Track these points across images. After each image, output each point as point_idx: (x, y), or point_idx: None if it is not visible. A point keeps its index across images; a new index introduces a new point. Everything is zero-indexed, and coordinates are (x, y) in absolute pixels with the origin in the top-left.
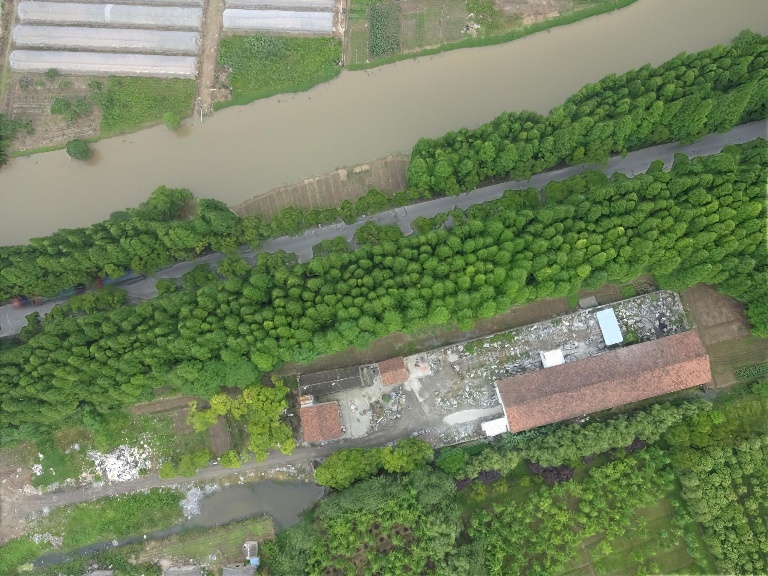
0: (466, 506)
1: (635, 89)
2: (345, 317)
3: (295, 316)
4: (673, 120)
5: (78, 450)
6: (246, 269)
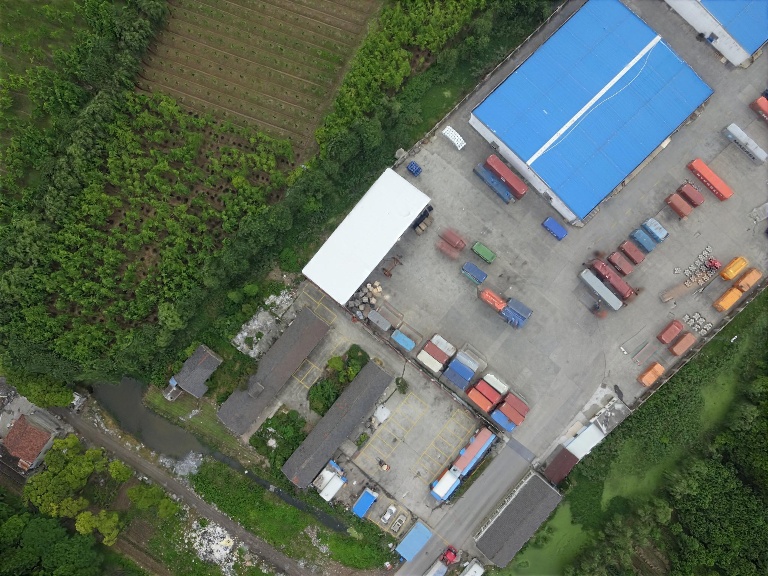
0: None
1: None
2: None
3: None
4: None
5: None
6: None
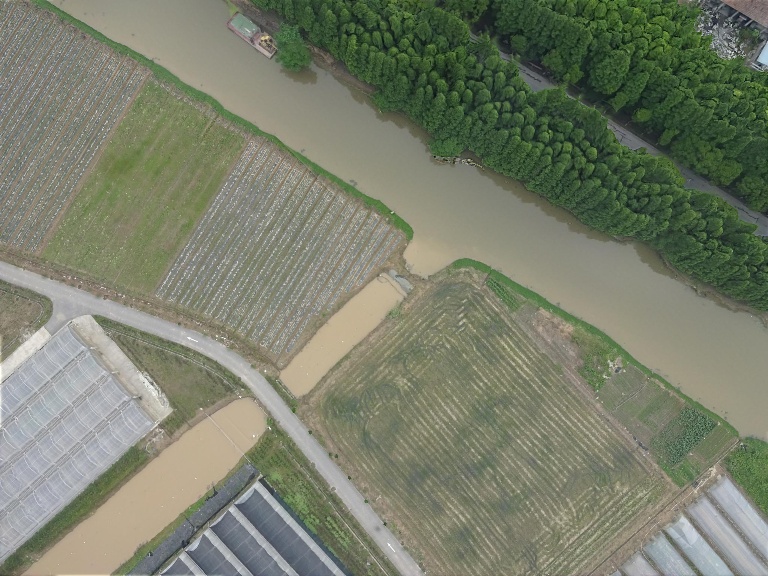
0: None
1: None
2: None
3: None
4: None
5: None
6: None
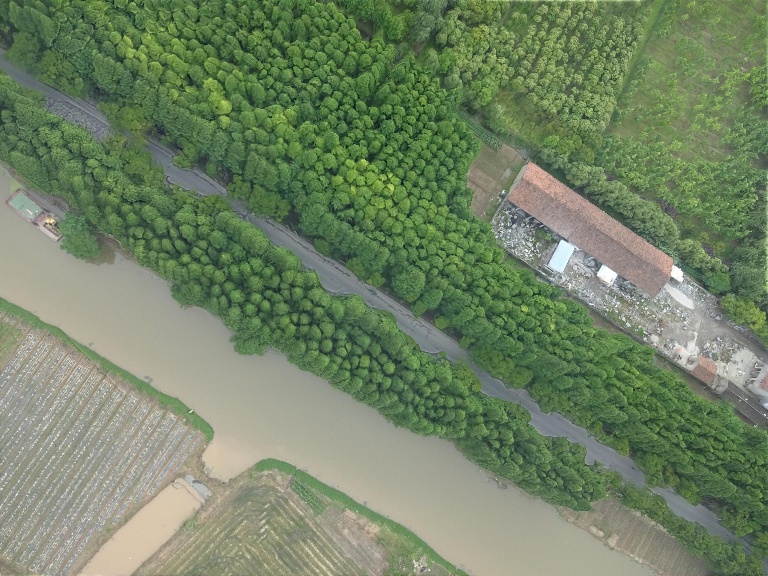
0: (724, 248)
1: None
2: None
3: (765, 469)
4: (404, 343)
5: None
6: (763, 535)
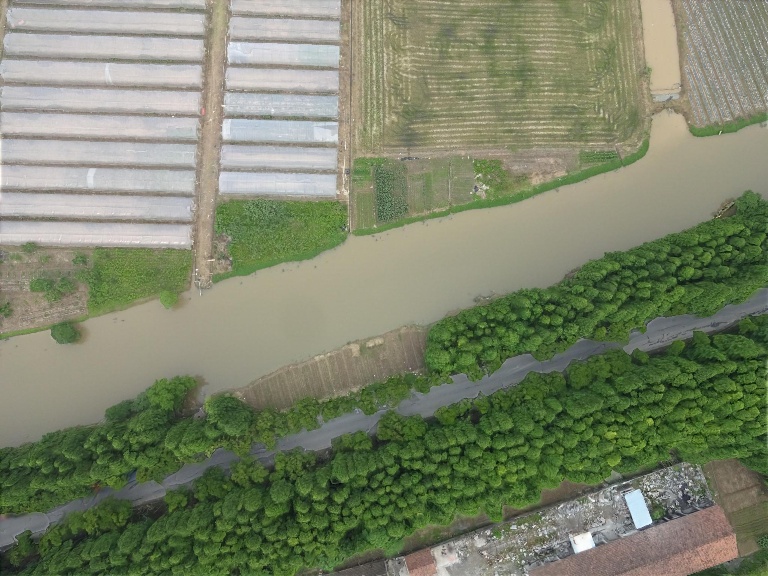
0: None
1: (655, 272)
2: (374, 526)
3: (321, 529)
4: (693, 301)
5: None
6: (264, 475)
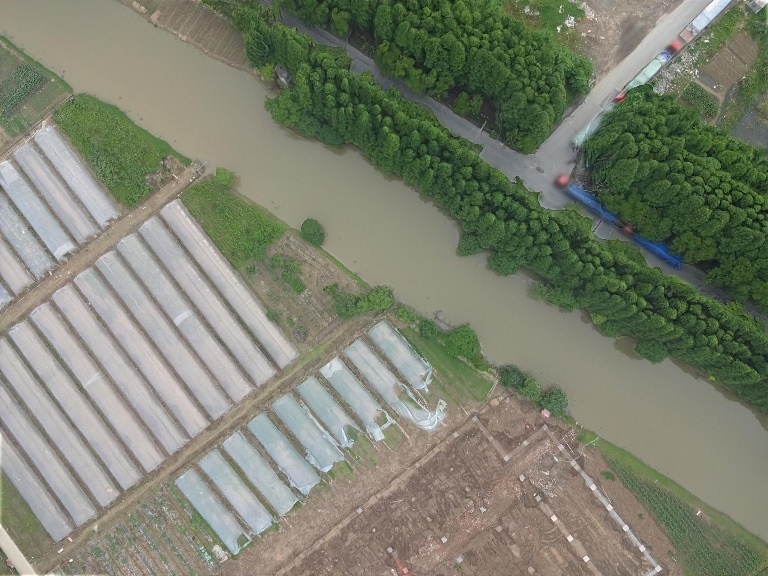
0: None
1: None
2: None
3: None
4: None
5: (528, 6)
6: None
